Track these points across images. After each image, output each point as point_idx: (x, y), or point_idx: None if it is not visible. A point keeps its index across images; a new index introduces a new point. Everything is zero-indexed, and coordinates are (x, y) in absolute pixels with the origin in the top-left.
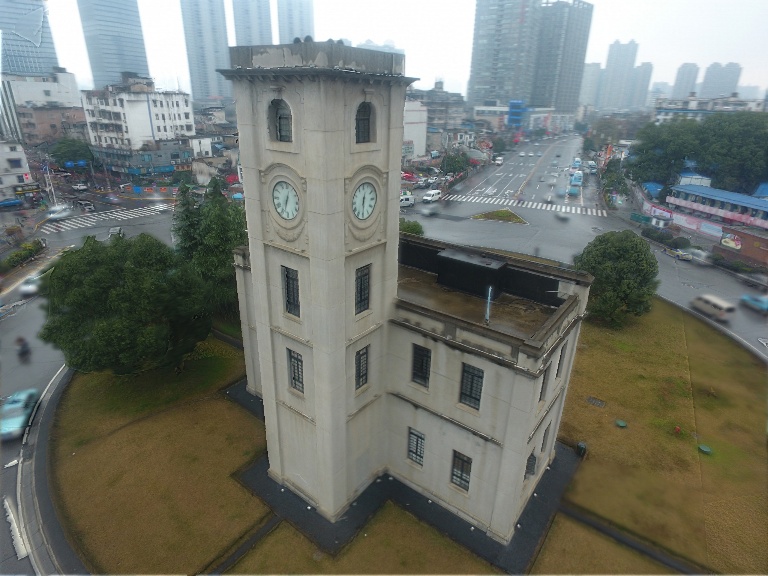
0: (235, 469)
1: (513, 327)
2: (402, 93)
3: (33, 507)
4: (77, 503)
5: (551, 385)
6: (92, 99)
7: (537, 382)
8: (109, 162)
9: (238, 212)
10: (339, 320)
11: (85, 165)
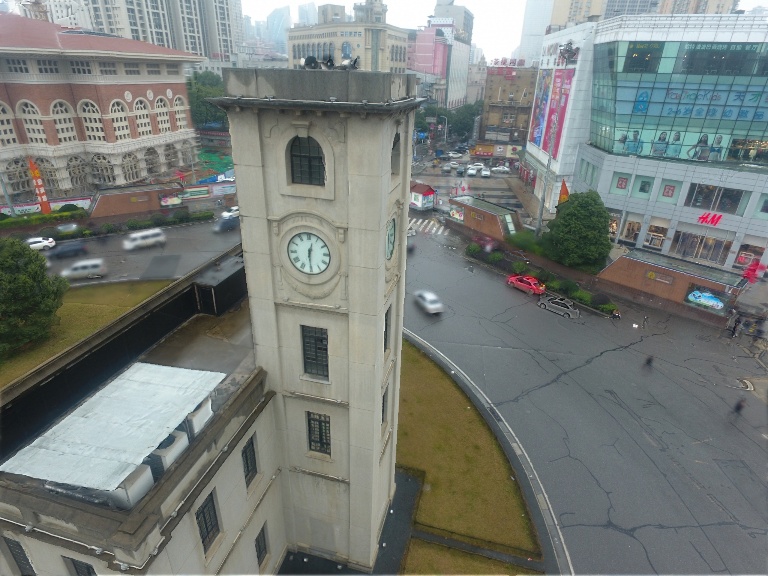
0: None
1: None
2: None
3: None
4: None
5: None
6: None
7: None
8: None
9: None
10: None
11: None
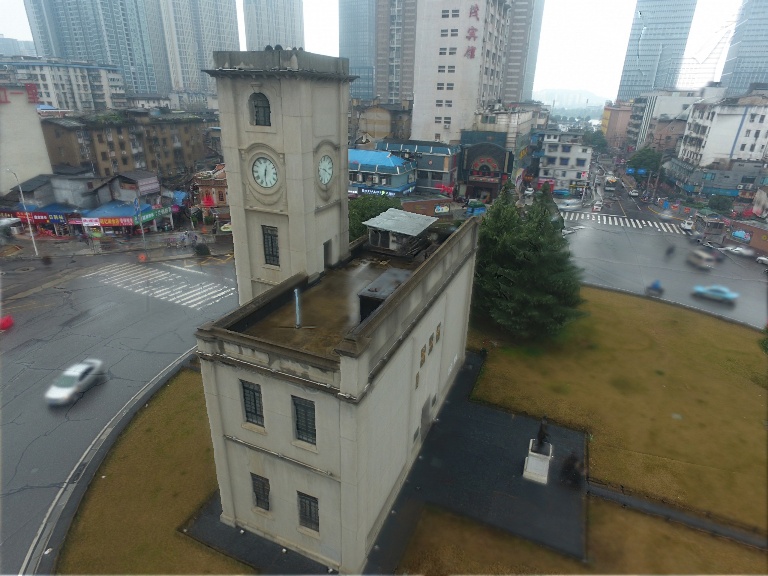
0: None
1: (288, 340)
2: (293, 85)
3: None
4: None
5: (280, 427)
6: (695, 112)
7: (212, 370)
8: (677, 176)
9: (504, 212)
10: (243, 255)
11: (645, 174)
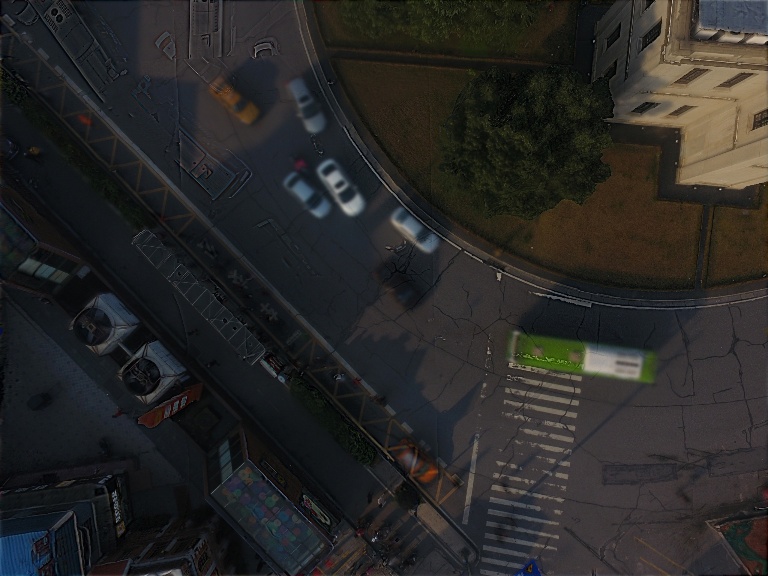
0: (652, 193)
1: None
2: None
3: (558, 286)
4: (583, 270)
5: None
6: None
7: None
8: None
9: None
10: None
11: None
